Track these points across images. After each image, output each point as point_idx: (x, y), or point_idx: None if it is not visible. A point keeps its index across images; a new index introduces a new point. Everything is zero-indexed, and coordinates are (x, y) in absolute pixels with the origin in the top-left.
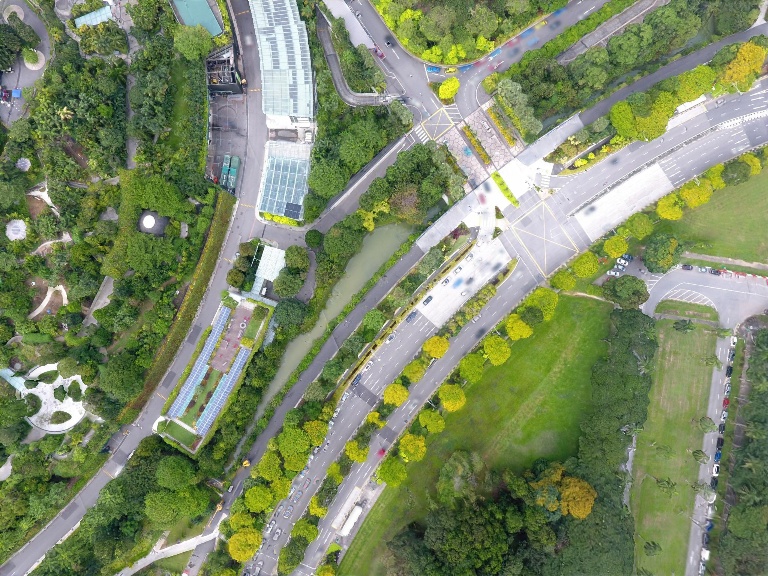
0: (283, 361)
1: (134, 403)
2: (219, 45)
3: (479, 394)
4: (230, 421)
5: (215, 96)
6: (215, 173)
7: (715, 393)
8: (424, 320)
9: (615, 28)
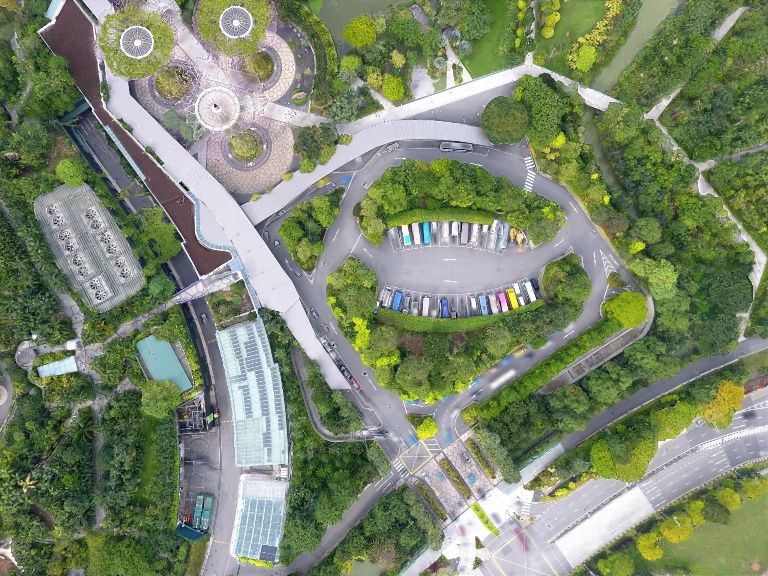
0: None
1: None
2: None
3: None
4: None
5: None
6: (188, 510)
7: None
8: None
9: (595, 349)
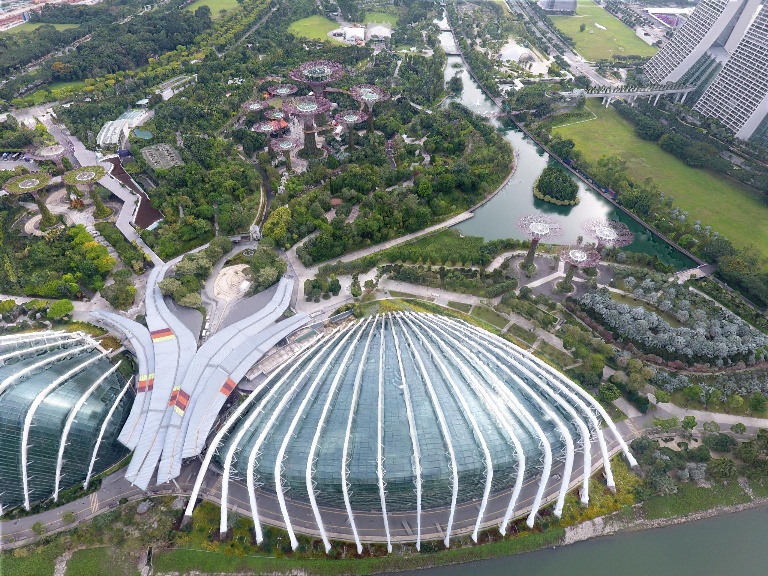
0: None
1: None
2: None
3: None
4: None
5: None
6: None
7: None
8: None
9: None
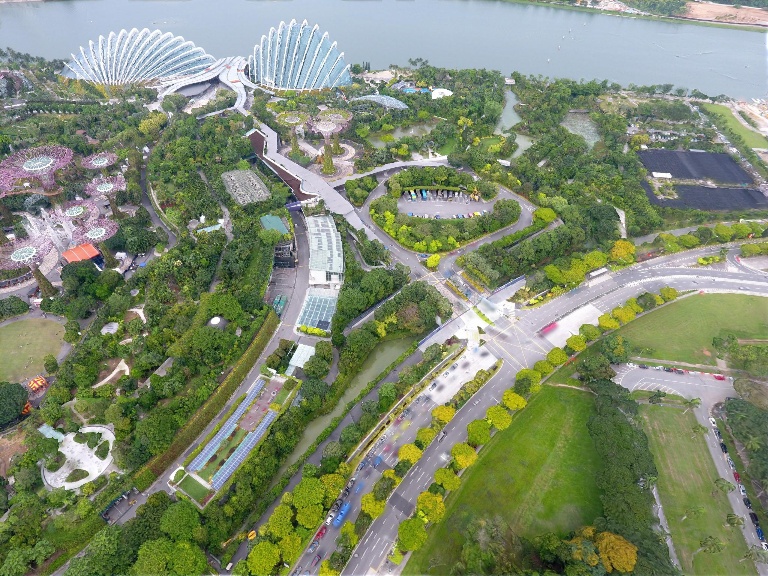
0: (303, 437)
1: (155, 463)
2: (285, 239)
3: (491, 467)
4: (248, 471)
5: (276, 268)
6: None
7: (721, 468)
8: (431, 402)
9: None
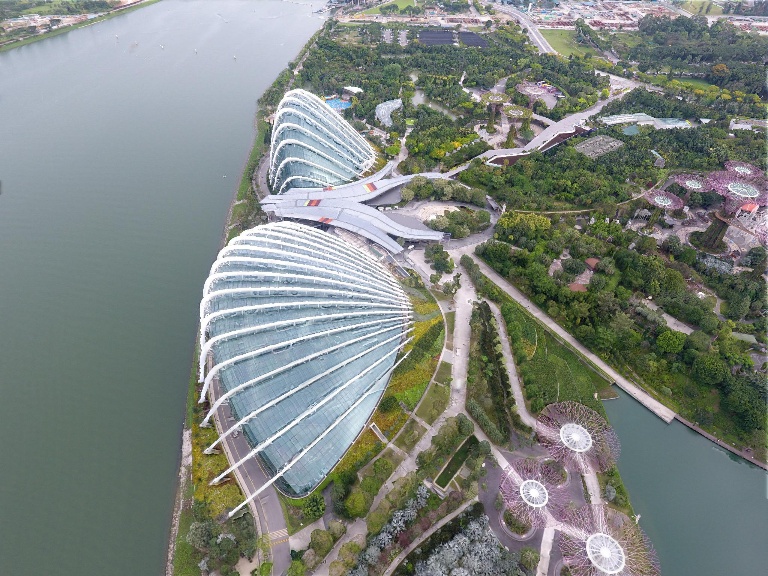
0: None
1: None
2: None
3: None
4: None
5: None
6: None
7: None
8: None
9: None
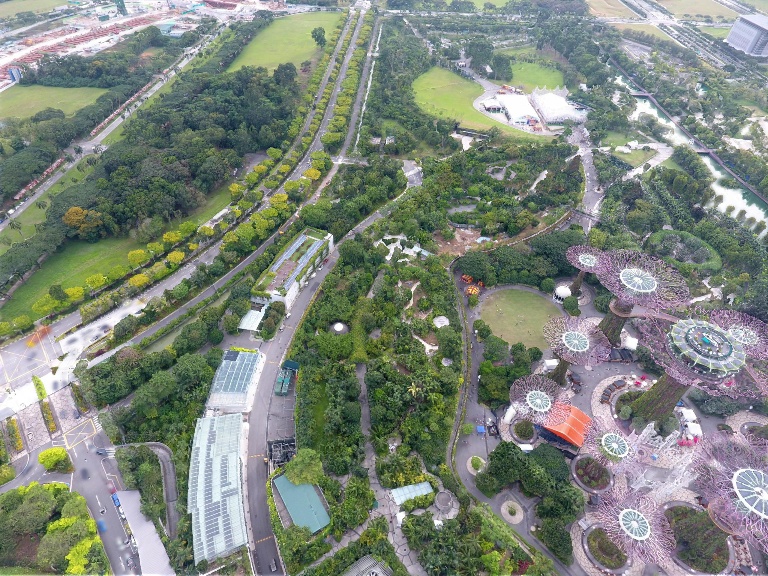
0: None
1: None
2: None
3: None
4: None
5: None
6: None
7: None
8: (146, 302)
9: None
